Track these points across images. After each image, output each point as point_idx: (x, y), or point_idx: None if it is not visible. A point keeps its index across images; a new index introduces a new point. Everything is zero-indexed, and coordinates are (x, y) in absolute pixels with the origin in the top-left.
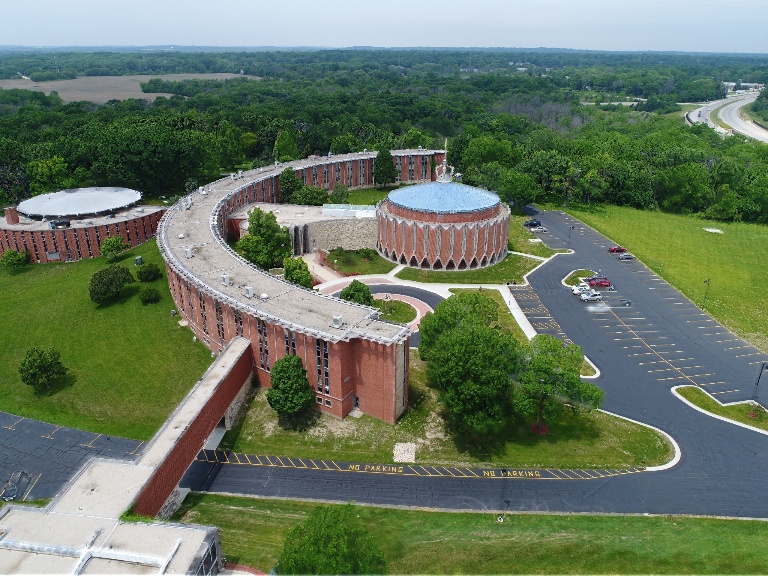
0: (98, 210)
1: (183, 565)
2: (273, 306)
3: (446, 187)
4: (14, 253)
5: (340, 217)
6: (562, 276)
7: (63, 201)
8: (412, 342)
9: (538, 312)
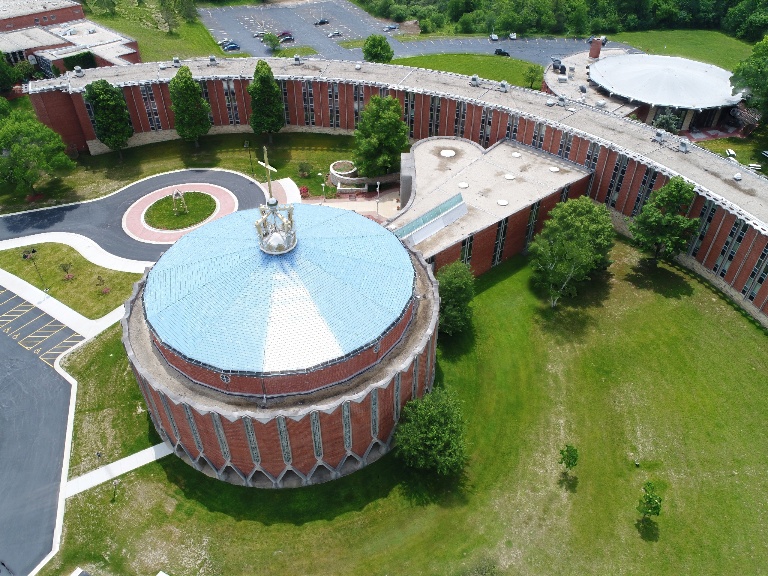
0: (611, 83)
1: (49, 57)
2: (147, 68)
3: (252, 237)
4: (534, 70)
5: (421, 214)
6: (3, 439)
7: (650, 66)
8: (115, 200)
9: (5, 313)
